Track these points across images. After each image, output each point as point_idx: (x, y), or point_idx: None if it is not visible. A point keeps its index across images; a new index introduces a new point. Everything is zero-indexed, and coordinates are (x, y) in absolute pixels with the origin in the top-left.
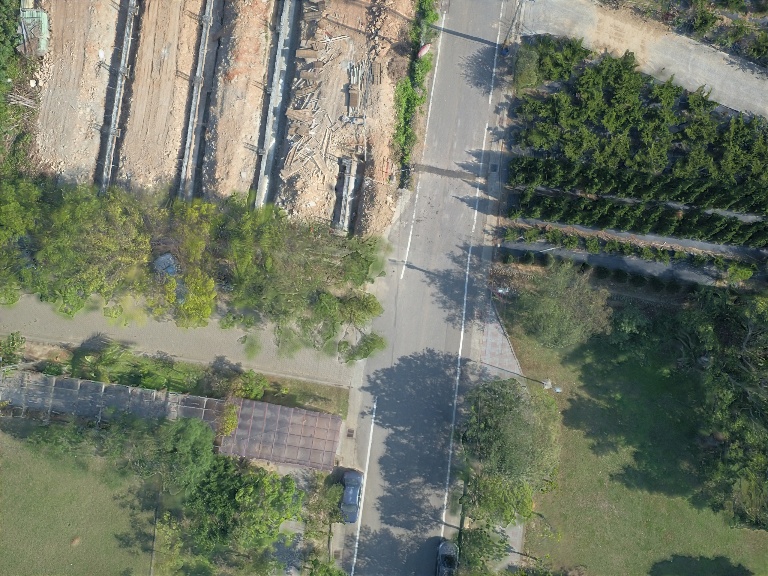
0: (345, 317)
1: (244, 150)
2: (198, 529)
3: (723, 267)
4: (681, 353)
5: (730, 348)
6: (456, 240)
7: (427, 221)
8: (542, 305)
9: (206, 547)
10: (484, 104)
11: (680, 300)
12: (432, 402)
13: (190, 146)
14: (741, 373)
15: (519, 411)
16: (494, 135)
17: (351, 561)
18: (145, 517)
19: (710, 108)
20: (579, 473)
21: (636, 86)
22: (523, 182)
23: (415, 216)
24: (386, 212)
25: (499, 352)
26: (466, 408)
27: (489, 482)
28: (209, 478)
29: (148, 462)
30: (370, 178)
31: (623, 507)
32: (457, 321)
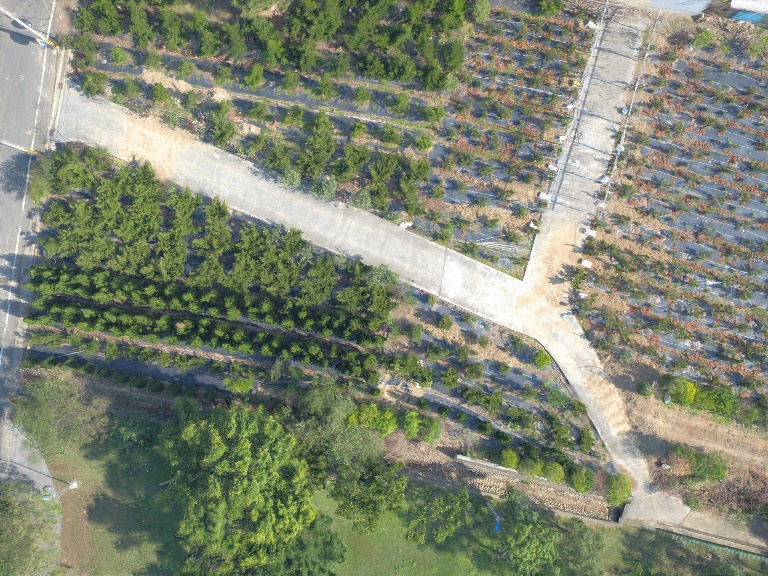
0: None
1: None
2: None
3: (238, 373)
4: None
5: (204, 461)
6: None
7: None
8: None
9: None
10: (17, 209)
11: None
12: None
13: None
14: (207, 487)
15: None
16: (27, 240)
17: None
18: None
19: (223, 218)
20: (103, 571)
21: (156, 195)
22: None
23: None
24: None
25: (28, 452)
26: None
27: None
28: None
29: None
30: None
31: None
32: None
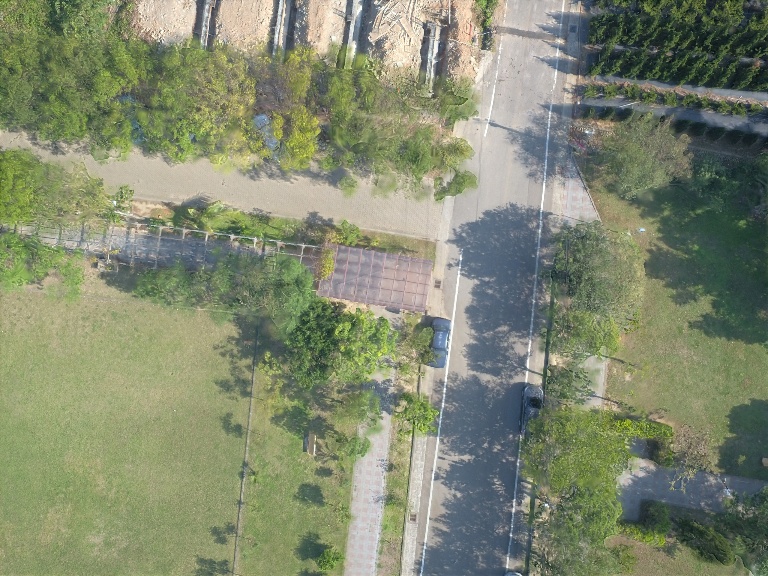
0: (432, 172)
1: (334, 16)
2: (299, 365)
3: None
4: (758, 200)
5: None
6: (537, 98)
7: (509, 81)
8: (625, 149)
9: (305, 385)
10: None
11: (756, 152)
12: (515, 254)
13: (282, 14)
14: None
15: (606, 246)
16: None
17: (439, 406)
18: (243, 366)
19: None
20: (658, 320)
21: None
22: (603, 38)
23: (497, 76)
24: (470, 72)
25: (580, 205)
26: (548, 259)
27: (579, 312)
28: (309, 317)
29: (258, 289)
30: (454, 40)
31: (701, 353)
32: (539, 176)
